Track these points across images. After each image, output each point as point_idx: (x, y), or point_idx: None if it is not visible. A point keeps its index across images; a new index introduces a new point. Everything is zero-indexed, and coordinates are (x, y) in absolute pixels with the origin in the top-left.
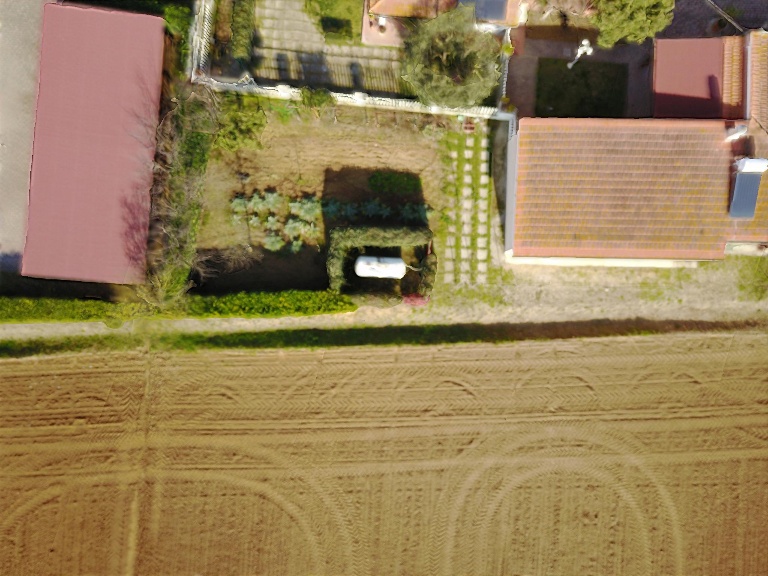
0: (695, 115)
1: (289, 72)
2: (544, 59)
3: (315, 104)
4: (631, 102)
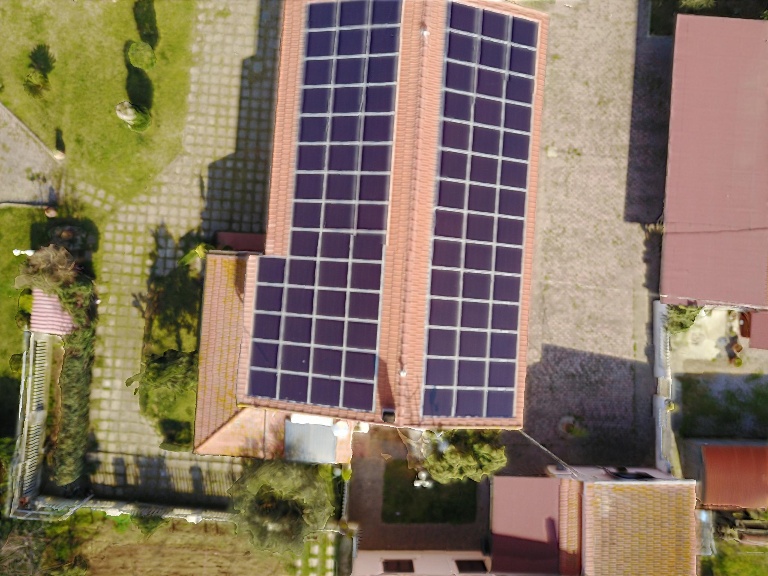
0: (531, 560)
1: (124, 477)
2: (390, 460)
3: (144, 532)
4: (480, 506)
